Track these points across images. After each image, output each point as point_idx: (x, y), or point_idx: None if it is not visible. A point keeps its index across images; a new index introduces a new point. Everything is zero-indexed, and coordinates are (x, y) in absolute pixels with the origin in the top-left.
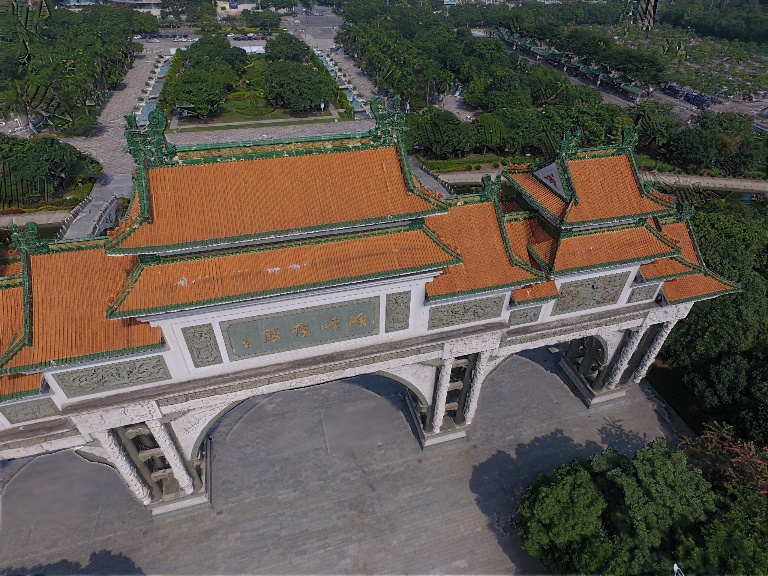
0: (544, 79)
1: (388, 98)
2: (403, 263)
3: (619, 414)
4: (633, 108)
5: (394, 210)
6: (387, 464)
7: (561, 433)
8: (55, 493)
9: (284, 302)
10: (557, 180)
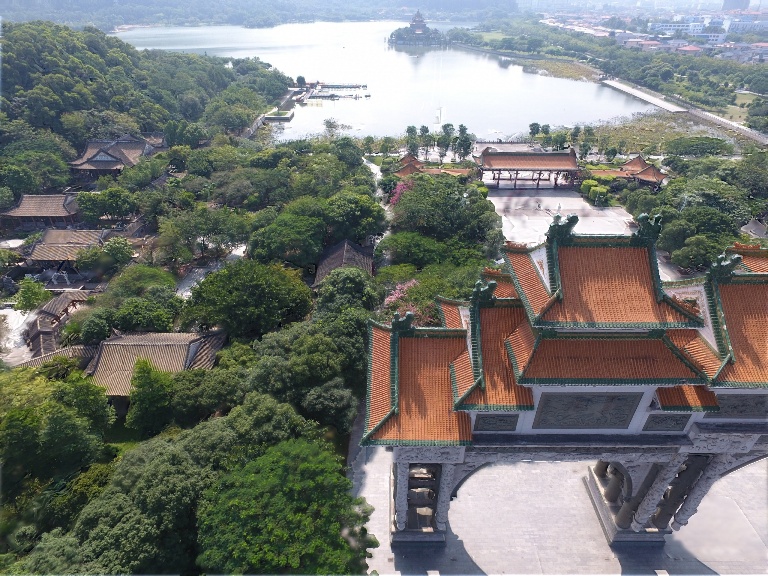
0: None
1: None
2: None
3: None
4: None
5: None
6: None
7: None
8: None
9: None
10: None
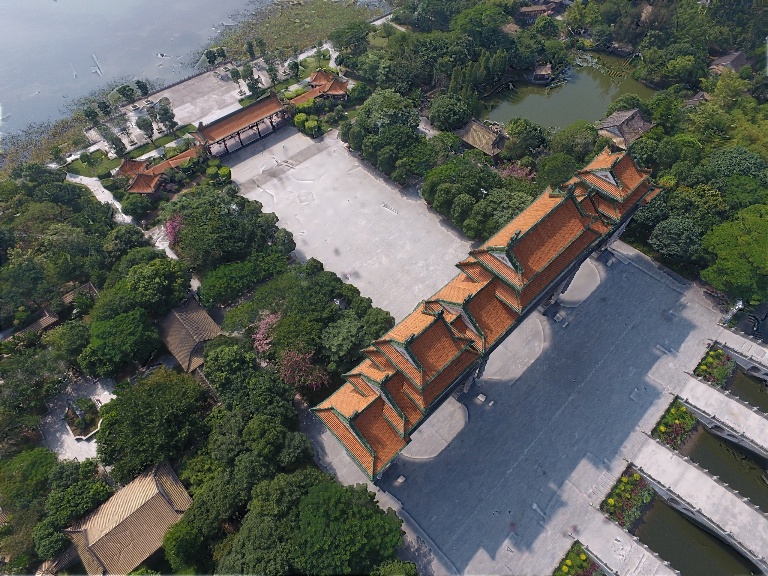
0: None
1: None
2: None
3: None
4: None
5: None
6: None
7: None
8: None
9: None
10: None
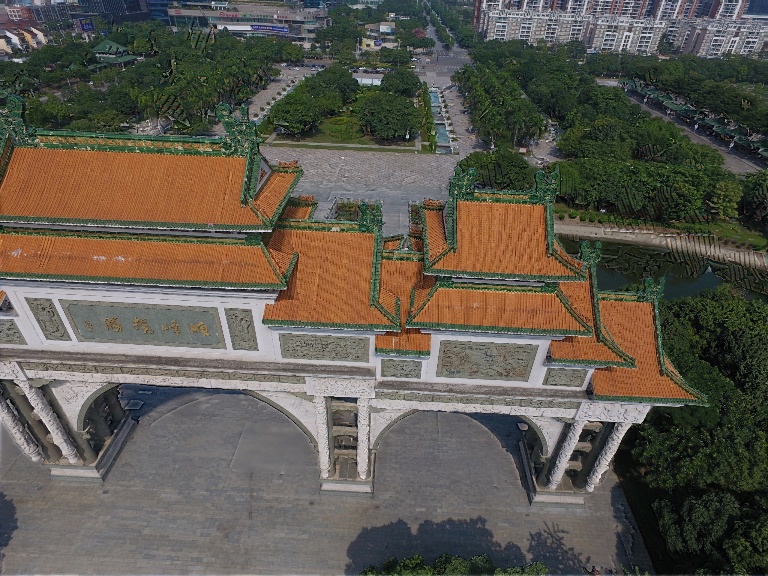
0: (655, 134)
1: (478, 137)
2: (227, 276)
3: (567, 524)
4: (753, 175)
5: (220, 219)
6: (278, 496)
7: (483, 523)
8: None
9: (117, 293)
10: None
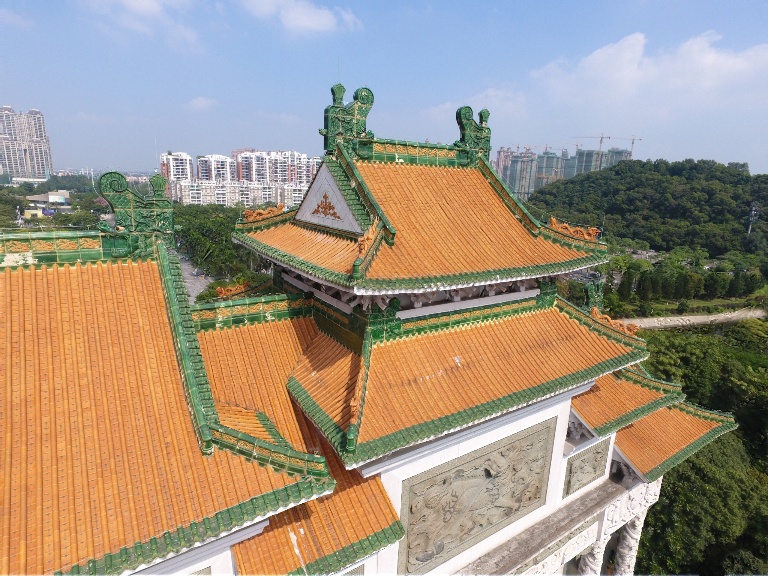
0: None
1: (208, 277)
2: None
3: None
4: None
5: None
6: None
7: None
8: None
9: None
10: (336, 200)
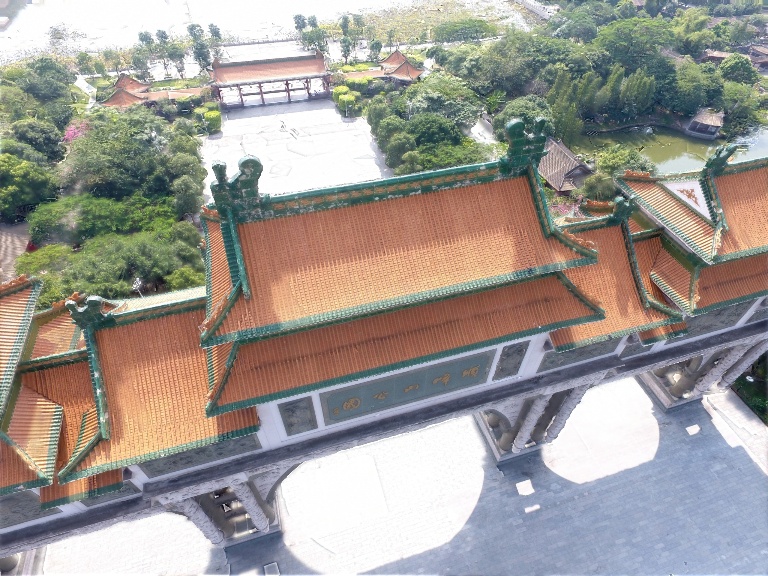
0: None
1: None
2: None
3: None
4: None
5: None
6: None
7: None
8: (608, 414)
9: None
10: None
